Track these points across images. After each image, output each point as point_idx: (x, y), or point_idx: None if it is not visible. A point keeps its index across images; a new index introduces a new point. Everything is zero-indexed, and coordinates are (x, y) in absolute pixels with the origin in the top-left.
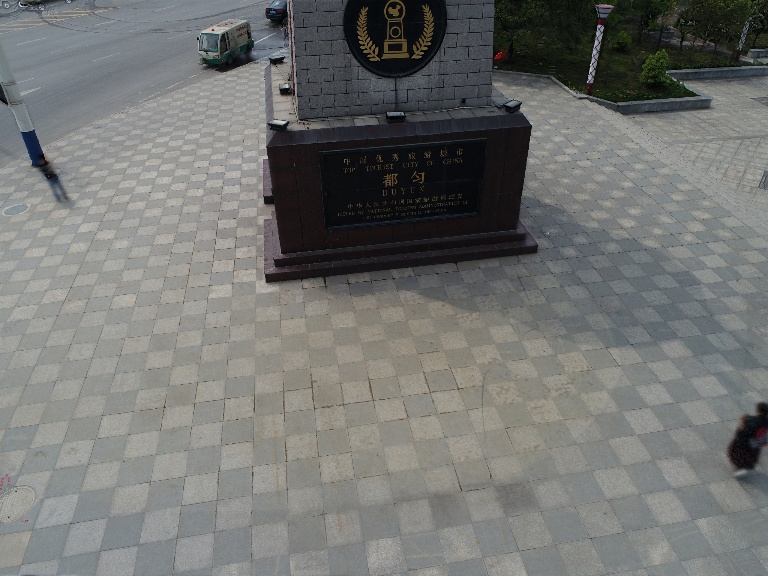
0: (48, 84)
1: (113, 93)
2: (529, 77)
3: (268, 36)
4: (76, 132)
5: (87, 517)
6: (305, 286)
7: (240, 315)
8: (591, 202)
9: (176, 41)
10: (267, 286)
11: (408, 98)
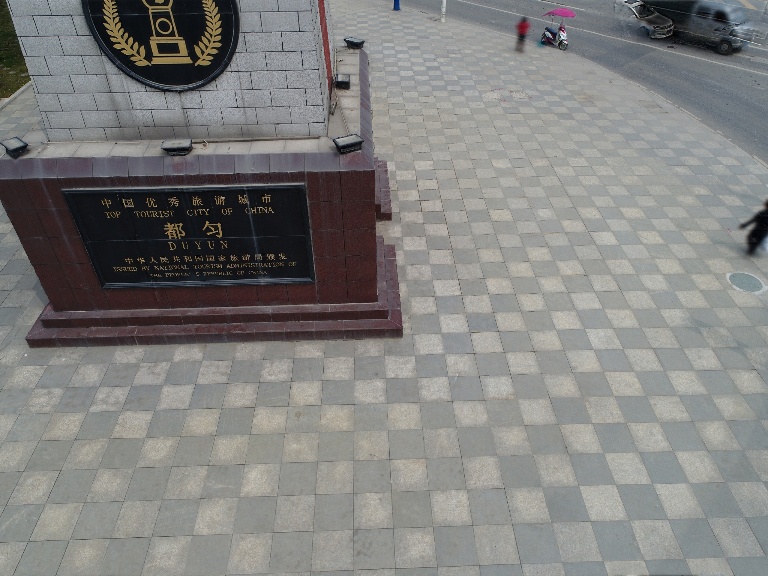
0: None
1: None
2: None
3: None
4: None
5: (457, 91)
6: None
7: (405, 149)
8: (6, 219)
9: None
10: None
11: None
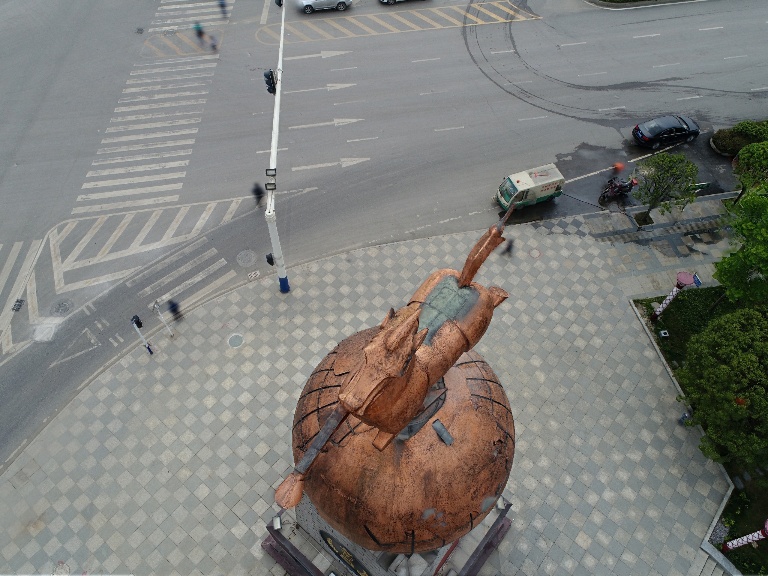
0: (378, 156)
1: (402, 204)
2: (713, 466)
3: (602, 170)
4: (334, 256)
5: None
6: (272, 570)
7: (228, 561)
8: None
9: (521, 130)
10: (259, 549)
11: (353, 574)
